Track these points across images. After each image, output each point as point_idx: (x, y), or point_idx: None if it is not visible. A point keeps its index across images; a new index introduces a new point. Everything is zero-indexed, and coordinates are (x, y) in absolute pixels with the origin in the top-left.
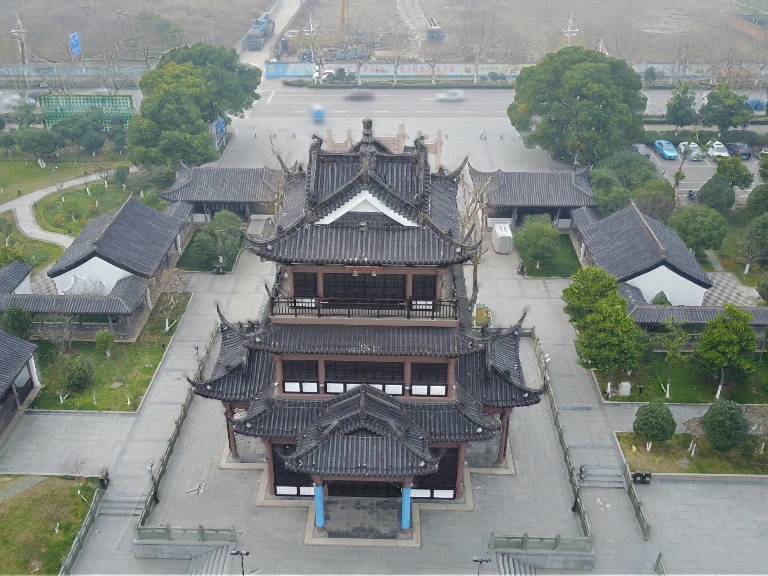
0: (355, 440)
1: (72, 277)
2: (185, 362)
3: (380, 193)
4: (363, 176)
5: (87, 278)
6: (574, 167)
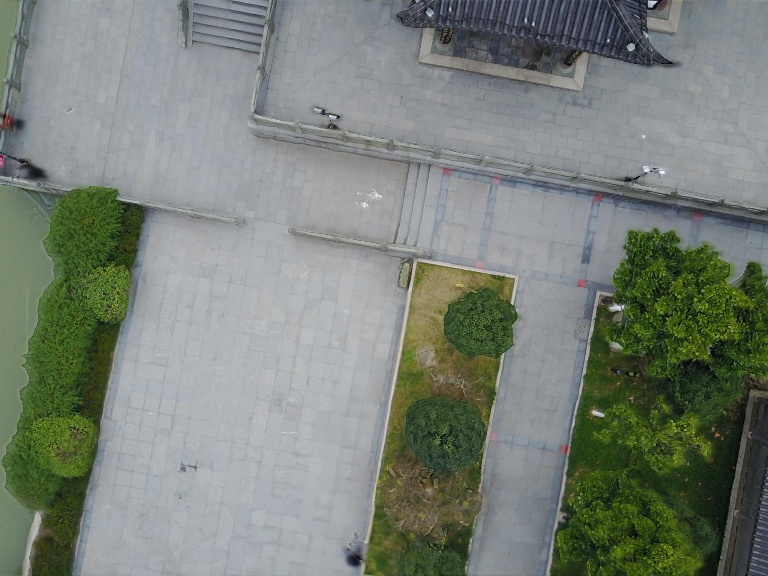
0: None
1: None
2: None
3: None
4: None
5: None
6: None
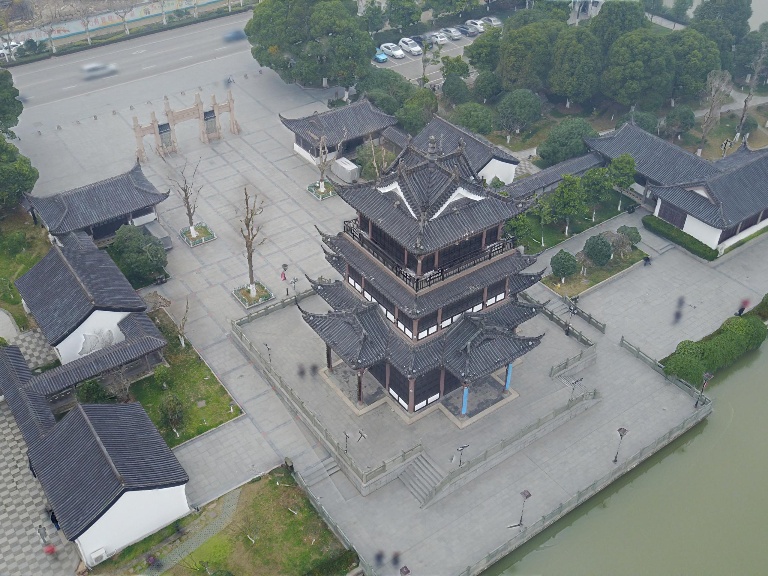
0: (483, 348)
1: (75, 338)
2: (229, 362)
3: (464, 185)
4: (457, 178)
5: (92, 332)
6: (336, 91)
